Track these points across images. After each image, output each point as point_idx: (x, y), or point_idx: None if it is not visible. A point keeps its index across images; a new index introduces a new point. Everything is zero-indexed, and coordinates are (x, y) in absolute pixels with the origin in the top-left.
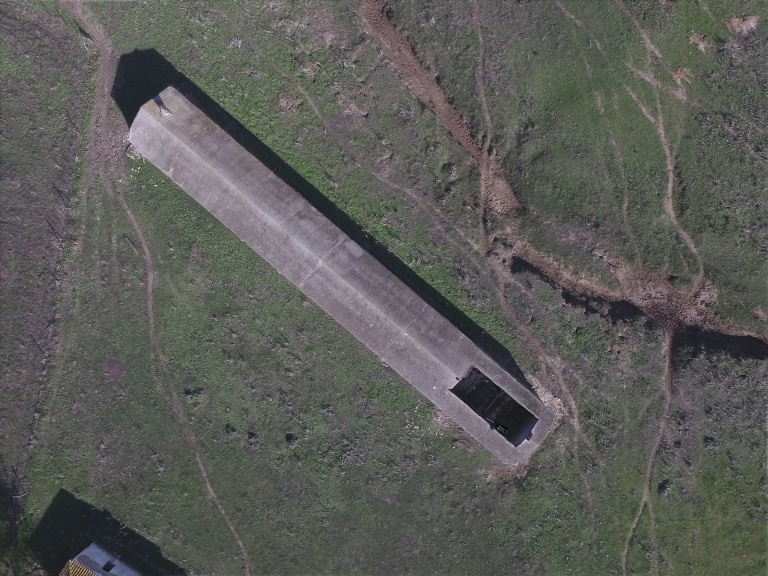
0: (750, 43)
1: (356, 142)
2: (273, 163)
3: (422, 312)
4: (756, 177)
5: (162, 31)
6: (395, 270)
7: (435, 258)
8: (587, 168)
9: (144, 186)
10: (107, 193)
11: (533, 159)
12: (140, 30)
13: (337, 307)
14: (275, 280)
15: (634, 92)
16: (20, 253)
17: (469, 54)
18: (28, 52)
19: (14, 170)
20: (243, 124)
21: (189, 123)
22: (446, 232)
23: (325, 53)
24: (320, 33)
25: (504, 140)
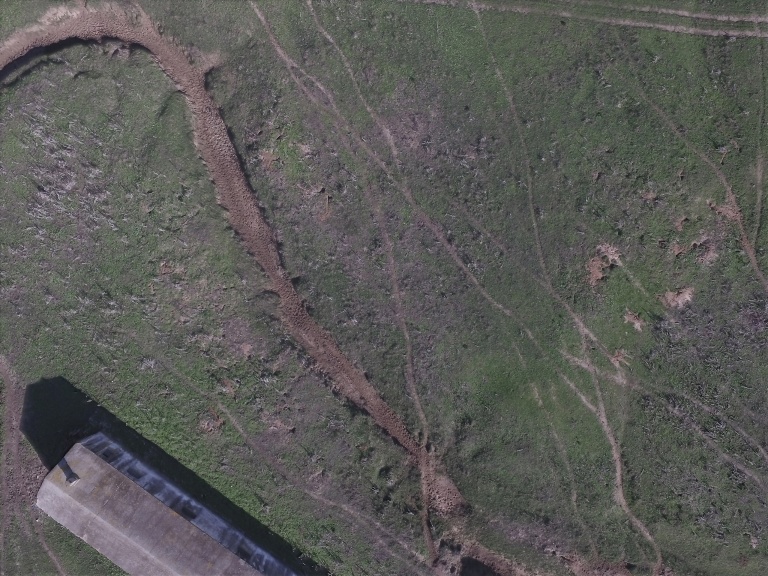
0: (687, 317)
1: (285, 460)
2: (199, 489)
3: None
4: (706, 460)
5: (68, 356)
6: None
7: (379, 575)
8: (530, 463)
9: None
10: (24, 535)
11: (473, 456)
12: (45, 358)
13: None
14: None
15: (572, 381)
16: None
17: (396, 352)
18: None
19: None
20: (163, 449)
21: (99, 486)
22: (388, 546)
23: (244, 366)
24: (237, 344)
25: (441, 438)
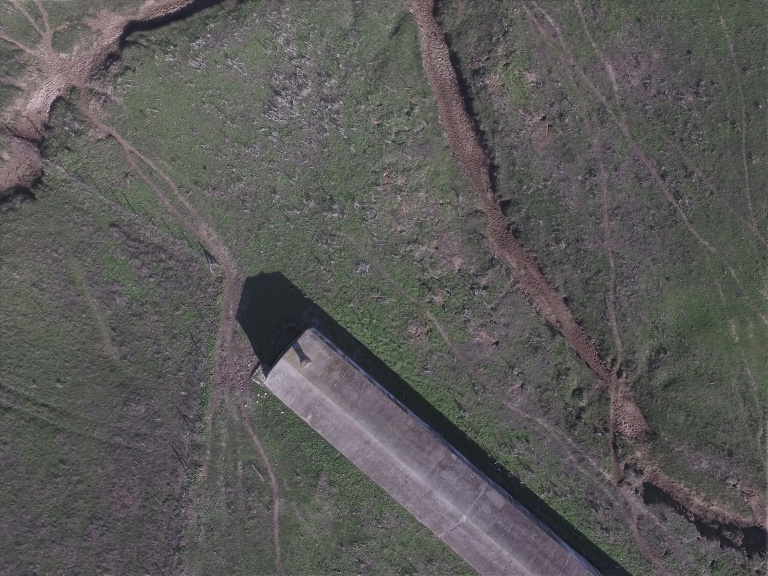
0: None
1: (486, 370)
2: (402, 390)
3: (566, 565)
4: None
5: (288, 254)
6: (527, 502)
7: (567, 489)
8: (721, 397)
9: (270, 412)
10: (232, 418)
11: (665, 385)
12: (266, 253)
13: (479, 559)
14: (404, 510)
15: None
16: (144, 479)
17: (600, 279)
18: (152, 275)
19: (139, 395)
20: (371, 350)
21: (328, 371)
22: (578, 462)
23: (454, 278)
24: (448, 257)
25: (635, 366)
